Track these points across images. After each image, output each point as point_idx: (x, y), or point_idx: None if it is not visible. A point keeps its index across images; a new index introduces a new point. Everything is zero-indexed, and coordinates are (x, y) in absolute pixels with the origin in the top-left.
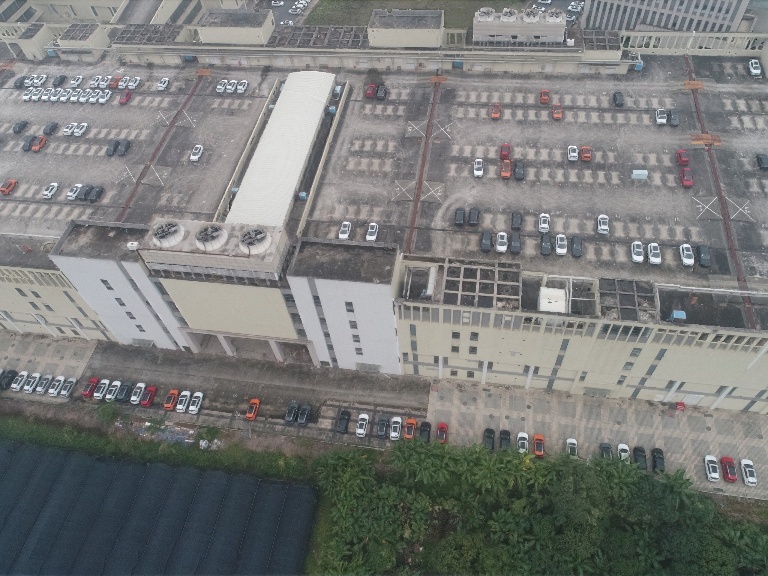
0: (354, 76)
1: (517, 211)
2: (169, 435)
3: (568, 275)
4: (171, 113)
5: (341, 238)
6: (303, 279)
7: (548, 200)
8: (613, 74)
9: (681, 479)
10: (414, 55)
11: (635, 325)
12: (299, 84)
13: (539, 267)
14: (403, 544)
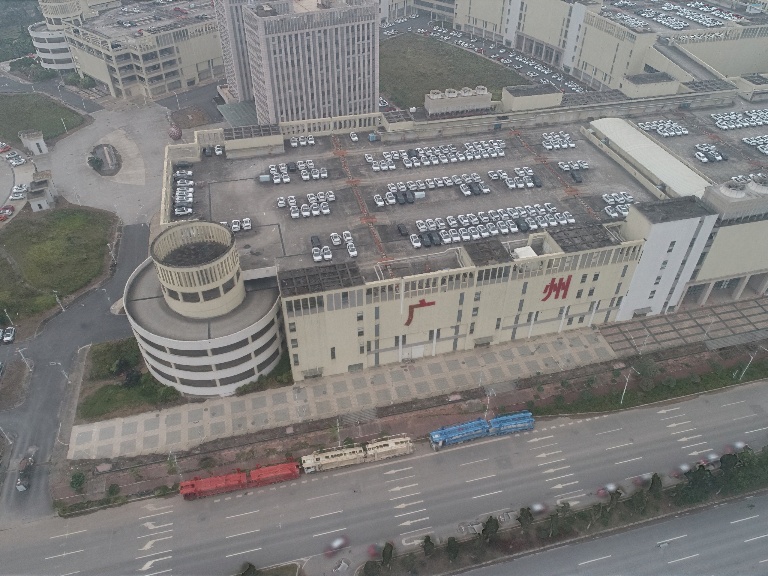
0: None
1: None
2: None
3: None
4: None
5: None
6: None
7: None
8: None
9: None
10: None
11: None
12: None
13: None
14: None
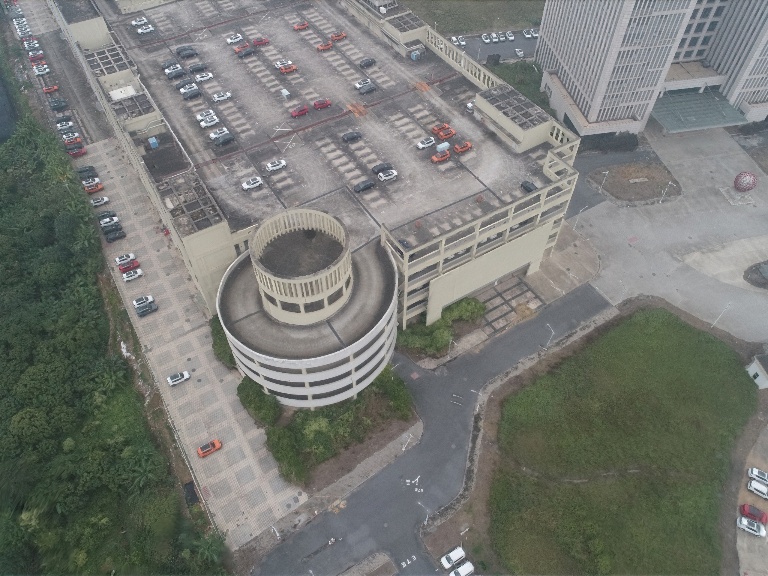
0: None
1: None
2: (19, 76)
3: (166, 101)
4: None
5: (132, 23)
6: (56, 4)
7: (230, 73)
8: (399, 53)
9: (91, 235)
10: None
11: None
12: None
13: (165, 90)
14: (2, 171)
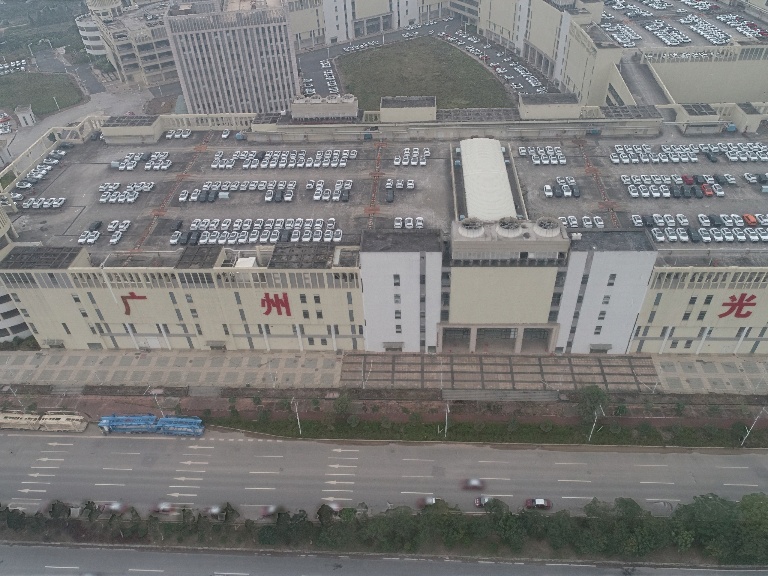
0: None
1: None
2: None
3: None
4: None
5: None
6: None
7: None
8: None
9: None
10: None
11: None
12: None
13: None
14: None
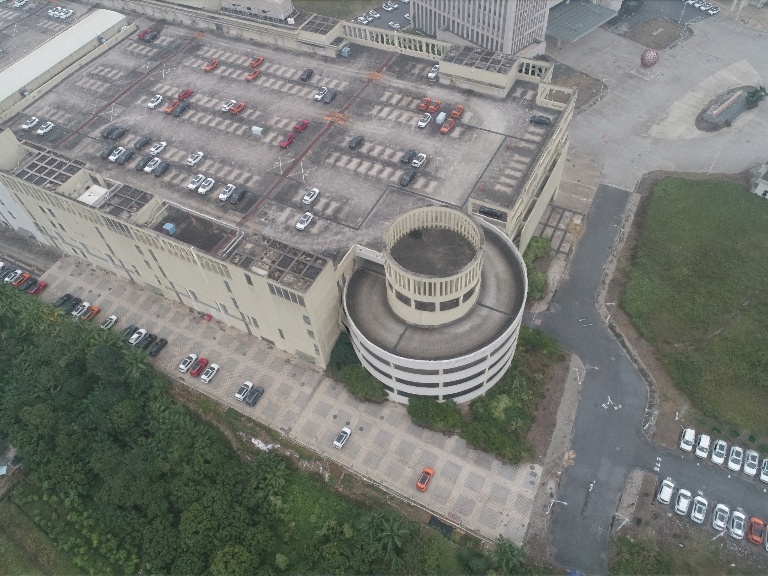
0: (147, 22)
1: (150, 137)
2: None
3: (138, 186)
4: (7, 24)
5: (23, 127)
6: None
7: (180, 135)
8: (326, 56)
9: None
10: (186, 12)
11: (116, 220)
12: (93, 18)
13: (126, 177)
14: None
